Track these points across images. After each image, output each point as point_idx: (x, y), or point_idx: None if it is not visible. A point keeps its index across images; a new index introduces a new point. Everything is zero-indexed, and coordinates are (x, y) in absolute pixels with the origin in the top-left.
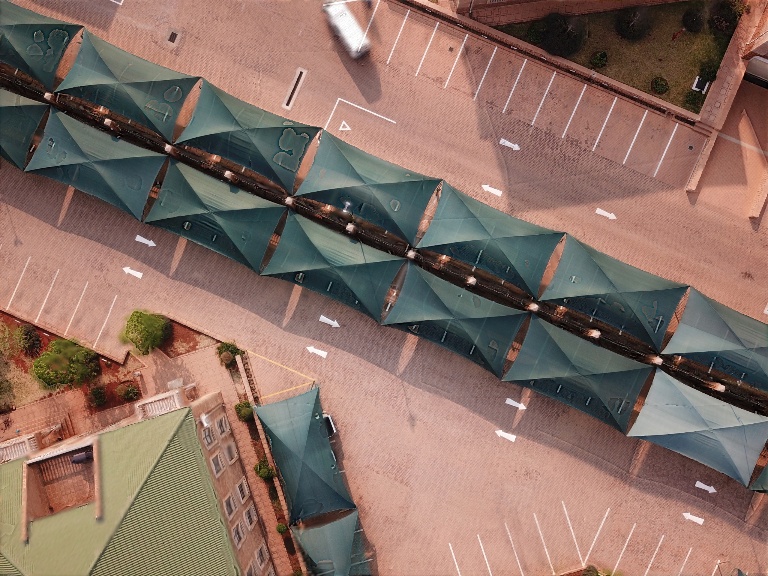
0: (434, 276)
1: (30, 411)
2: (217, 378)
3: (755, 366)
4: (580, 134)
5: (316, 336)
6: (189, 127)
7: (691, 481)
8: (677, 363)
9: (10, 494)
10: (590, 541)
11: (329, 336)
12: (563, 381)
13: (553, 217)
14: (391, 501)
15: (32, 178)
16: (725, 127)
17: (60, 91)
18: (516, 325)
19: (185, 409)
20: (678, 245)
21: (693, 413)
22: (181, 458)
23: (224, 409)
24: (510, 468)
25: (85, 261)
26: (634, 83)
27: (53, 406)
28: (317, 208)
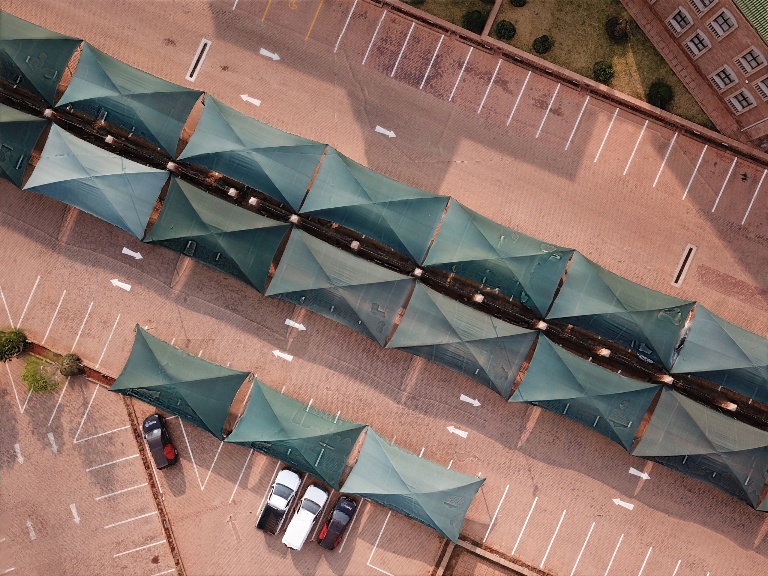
0: None
1: None
2: None
3: (132, 113)
4: None
5: None
6: None
7: (118, 247)
8: (96, 127)
9: None
10: (21, 309)
11: None
12: None
13: None
14: None
15: None
16: None
17: None
18: None
19: None
20: (103, 13)
21: (75, 161)
22: None
23: None
24: None
25: None
26: None
27: None
28: None
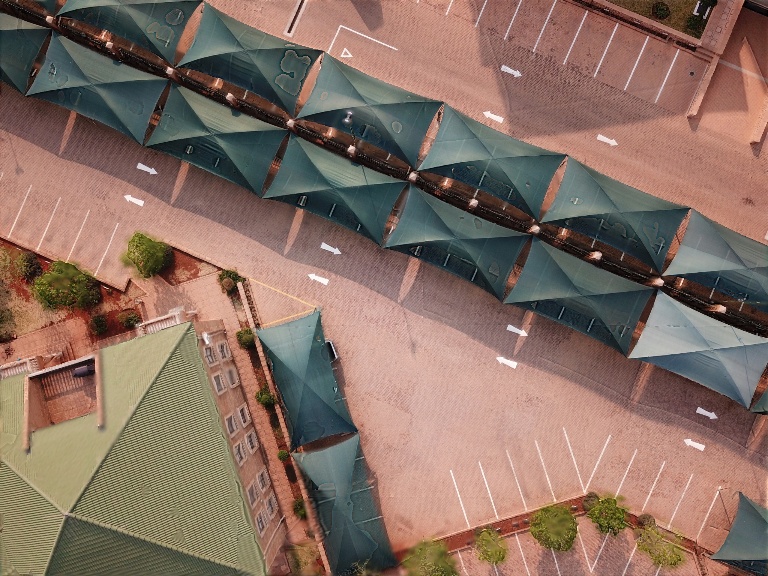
0: (436, 198)
1: (31, 340)
2: (218, 306)
3: (756, 286)
4: (581, 60)
5: (317, 263)
6: (191, 50)
7: (692, 407)
8: (678, 288)
9: (12, 406)
10: (591, 468)
11: (330, 263)
12: (564, 302)
13: (554, 143)
14: (392, 428)
15: (34, 105)
16: (726, 54)
17: (62, 14)
18: (517, 247)
19: (187, 323)
20: (679, 171)
21: (694, 333)
22: (183, 371)
23: (225, 336)
24: (511, 395)
25: (86, 189)
26: (635, 8)
27: (54, 335)
28: (319, 134)
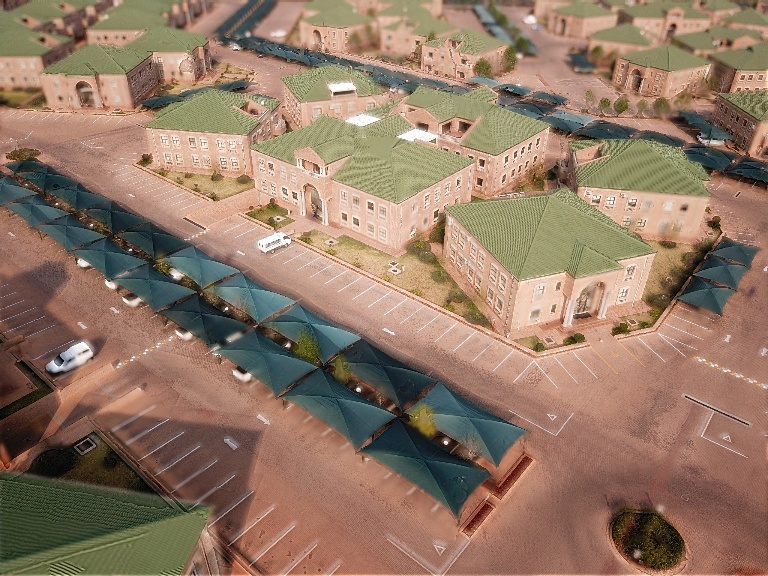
0: None
1: None
2: None
3: None
4: None
5: None
6: None
7: None
8: None
9: None
10: None
11: None
12: None
13: None
14: None
15: None
16: None
17: None
18: None
19: (761, 120)
20: None
21: None
22: None
23: (744, 150)
24: None
25: None
26: None
27: None
28: None
